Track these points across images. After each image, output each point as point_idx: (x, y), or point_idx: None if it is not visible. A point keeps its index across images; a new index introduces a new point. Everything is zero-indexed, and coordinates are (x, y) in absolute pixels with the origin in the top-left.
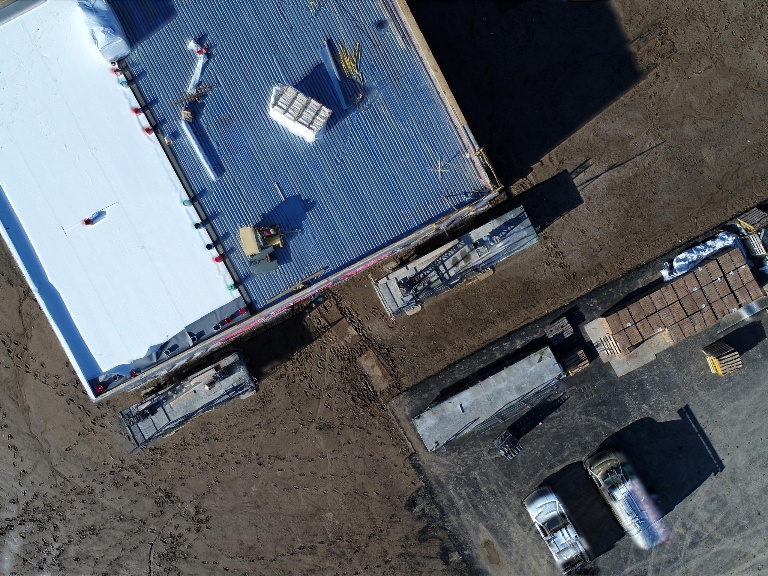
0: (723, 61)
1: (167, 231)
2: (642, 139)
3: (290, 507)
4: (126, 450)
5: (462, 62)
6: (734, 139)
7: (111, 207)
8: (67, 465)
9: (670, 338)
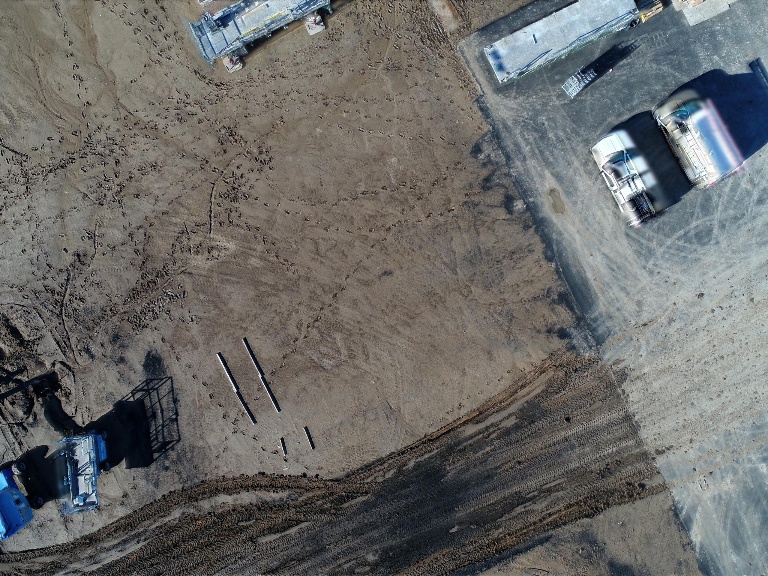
0: None
1: None
2: None
3: (355, 150)
4: (192, 85)
5: None
6: None
7: None
8: (132, 98)
9: None
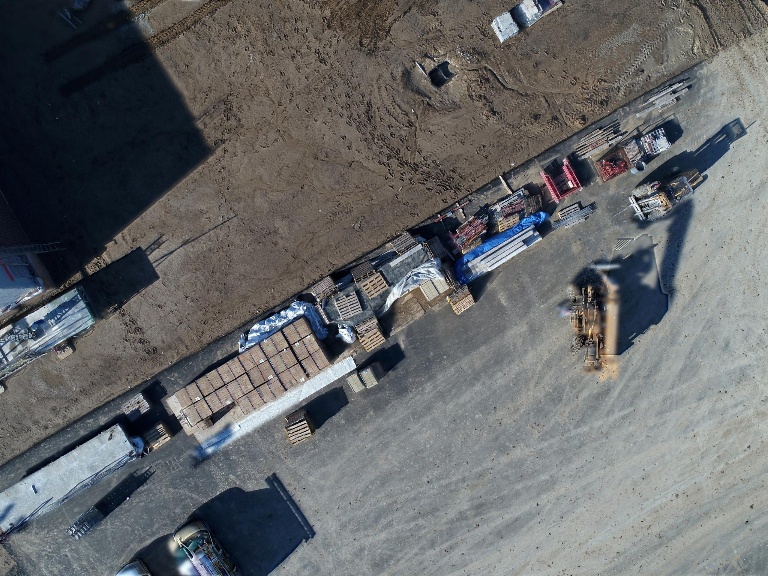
0: (290, 134)
1: None
2: (214, 214)
3: None
4: None
5: (29, 147)
6: (306, 209)
7: None
8: None
9: None
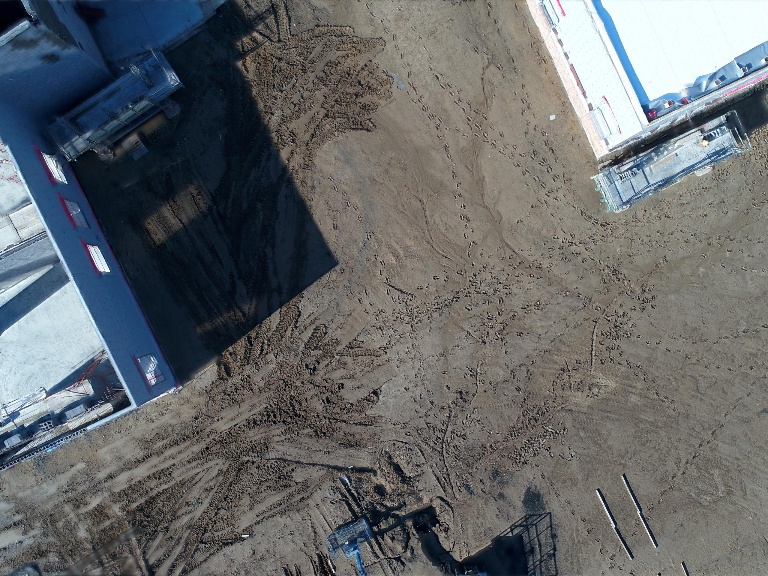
0: None
1: None
2: None
3: (737, 289)
4: (577, 225)
5: None
6: None
7: None
8: (517, 238)
9: None
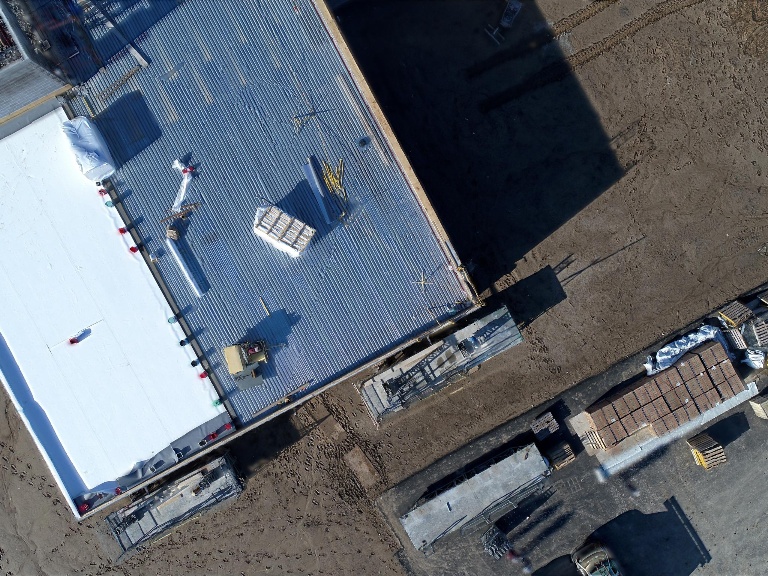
0: (701, 157)
1: (152, 347)
2: (623, 234)
3: None
4: (113, 550)
5: (445, 162)
6: (714, 233)
7: (96, 325)
8: (54, 566)
9: (654, 433)
